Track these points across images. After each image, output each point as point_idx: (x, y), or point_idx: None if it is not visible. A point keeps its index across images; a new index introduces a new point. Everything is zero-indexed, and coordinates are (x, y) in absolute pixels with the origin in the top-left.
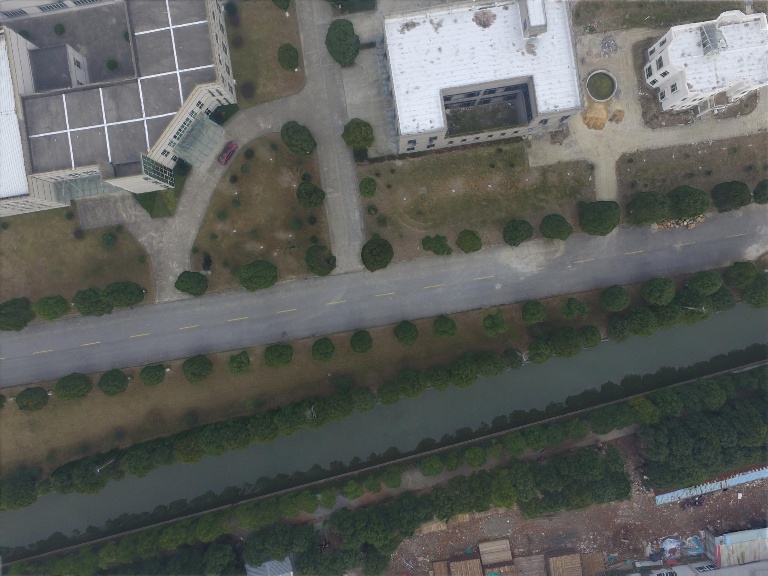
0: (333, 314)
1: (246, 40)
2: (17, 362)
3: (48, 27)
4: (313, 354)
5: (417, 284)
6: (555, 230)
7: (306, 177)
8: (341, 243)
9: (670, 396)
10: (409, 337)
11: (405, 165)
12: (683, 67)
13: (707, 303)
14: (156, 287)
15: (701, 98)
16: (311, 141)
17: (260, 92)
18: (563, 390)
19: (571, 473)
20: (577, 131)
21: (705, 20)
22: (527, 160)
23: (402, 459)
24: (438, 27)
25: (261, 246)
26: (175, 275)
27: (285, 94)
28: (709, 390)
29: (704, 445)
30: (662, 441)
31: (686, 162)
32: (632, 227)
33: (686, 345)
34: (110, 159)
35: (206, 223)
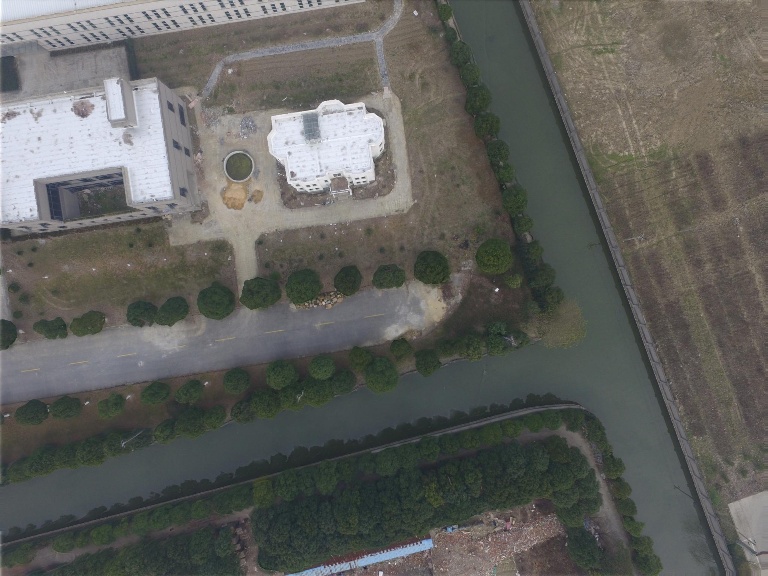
0: None
1: None
2: None
3: None
4: None
5: (62, 360)
6: None
7: None
8: None
9: (284, 480)
10: (23, 419)
11: (48, 243)
12: (287, 155)
13: (320, 388)
14: None
15: (314, 184)
16: None
17: None
18: (228, 462)
19: (174, 557)
20: (217, 211)
21: (343, 101)
22: (168, 239)
23: (52, 531)
24: (38, 117)
25: None
26: None
27: None
28: (322, 474)
29: (296, 533)
30: (261, 527)
31: (323, 243)
32: (271, 306)
33: (330, 423)
34: None
35: None
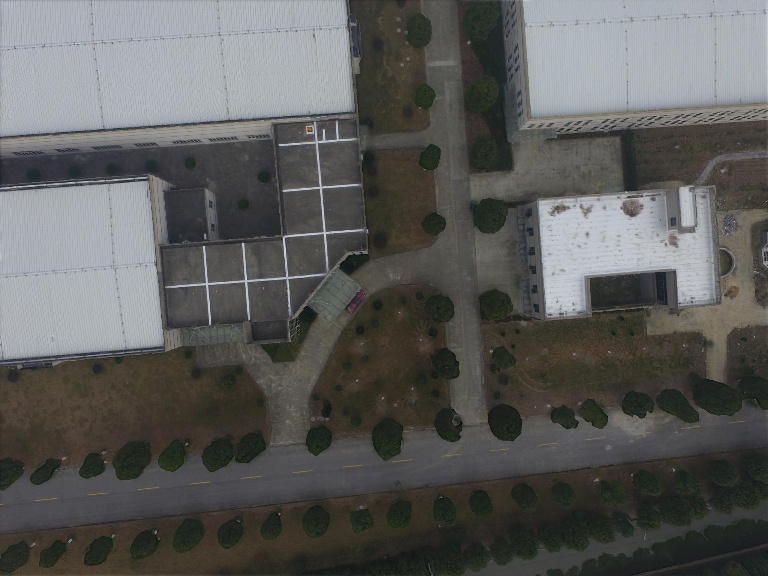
0: (447, 466)
1: (382, 190)
2: (120, 498)
3: (177, 158)
4: (438, 519)
5: (531, 441)
6: (679, 413)
7: (433, 332)
8: (461, 397)
9: (767, 569)
10: (532, 506)
11: (529, 326)
12: None
13: None
14: (271, 430)
15: None
16: (453, 312)
17: (392, 243)
18: (652, 539)
19: None
20: None
21: None
22: (645, 328)
23: None
24: (587, 212)
25: (382, 397)
26: (292, 419)
27: (417, 247)
28: None
29: None
30: None
31: None
32: None
33: None
34: (249, 316)
35: (328, 370)
